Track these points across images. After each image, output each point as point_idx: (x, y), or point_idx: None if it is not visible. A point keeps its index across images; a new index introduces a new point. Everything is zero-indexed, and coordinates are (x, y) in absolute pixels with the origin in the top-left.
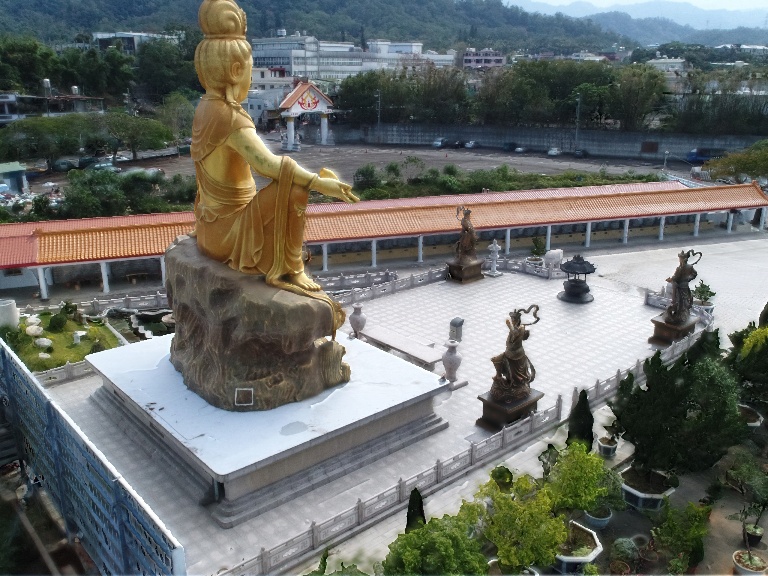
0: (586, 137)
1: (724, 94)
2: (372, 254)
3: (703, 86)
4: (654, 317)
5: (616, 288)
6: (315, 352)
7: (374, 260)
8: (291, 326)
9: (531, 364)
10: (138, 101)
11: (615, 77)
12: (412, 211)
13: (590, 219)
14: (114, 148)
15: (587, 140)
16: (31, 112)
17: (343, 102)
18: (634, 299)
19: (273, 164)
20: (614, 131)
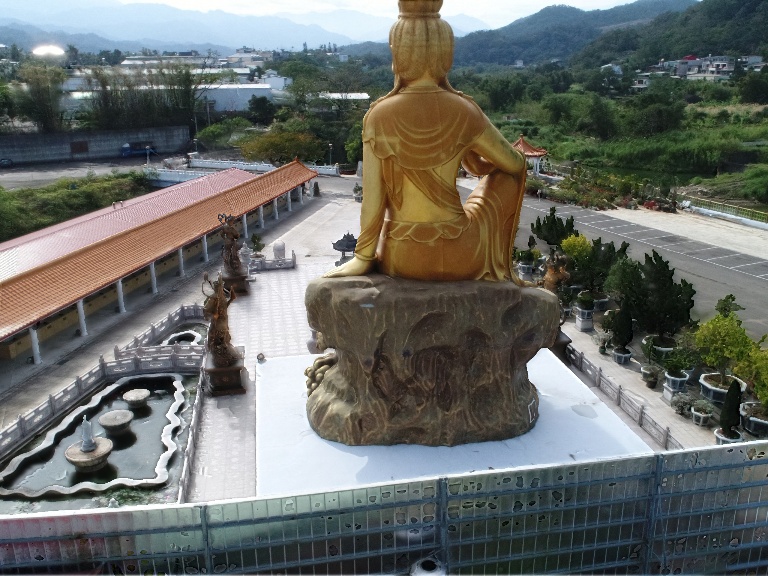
0: (3, 144)
1: (132, 89)
2: (120, 297)
3: (112, 82)
4: None
5: None
6: None
7: (123, 304)
8: None
9: None
10: None
11: (14, 75)
12: (129, 236)
13: (250, 210)
14: None
15: (5, 147)
16: None
17: None
18: None
19: None
20: (35, 134)
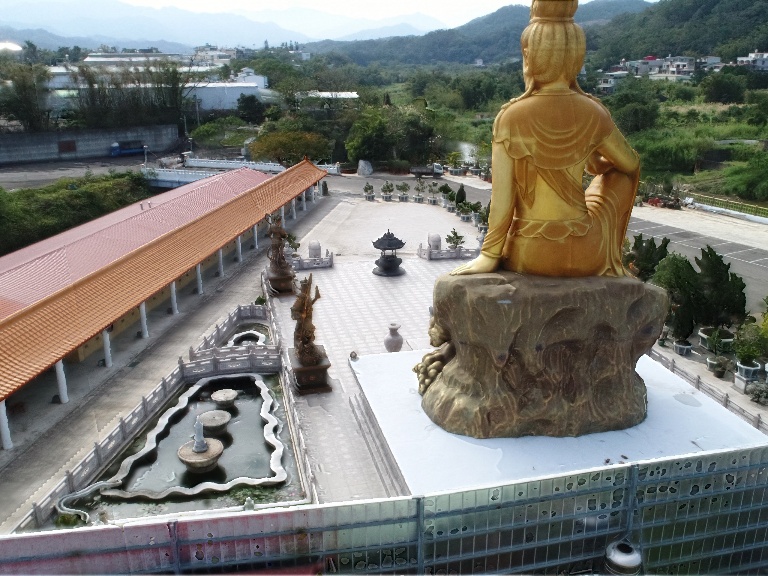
0: None
1: (119, 88)
2: (173, 298)
3: (100, 80)
4: None
5: (374, 259)
6: None
7: (176, 305)
8: None
9: None
10: None
11: None
12: (175, 237)
13: None
14: None
15: None
16: None
17: None
18: (410, 260)
19: None
20: (21, 133)
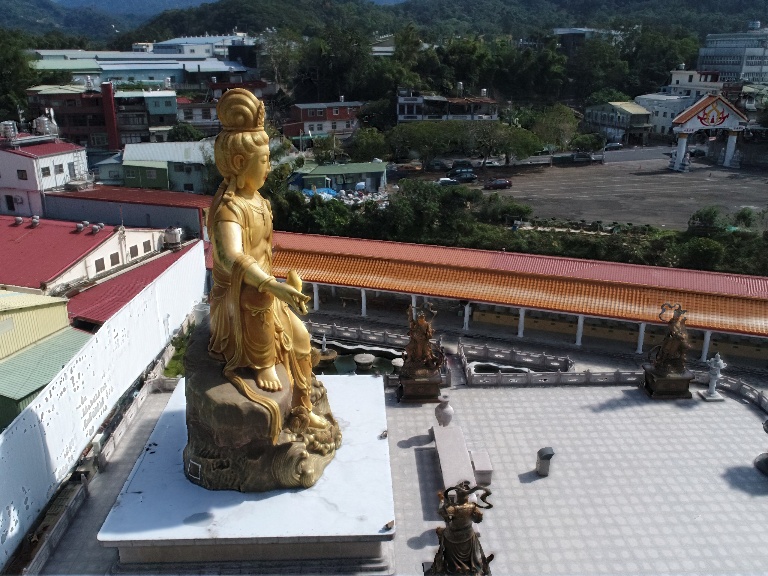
0: None
1: None
2: (577, 330)
3: None
4: None
5: None
6: (271, 449)
7: (579, 338)
8: (216, 422)
9: (483, 554)
10: (521, 109)
11: None
12: (642, 290)
13: None
14: (485, 154)
15: None
16: (433, 113)
17: (767, 117)
18: None
19: (228, 262)
20: None
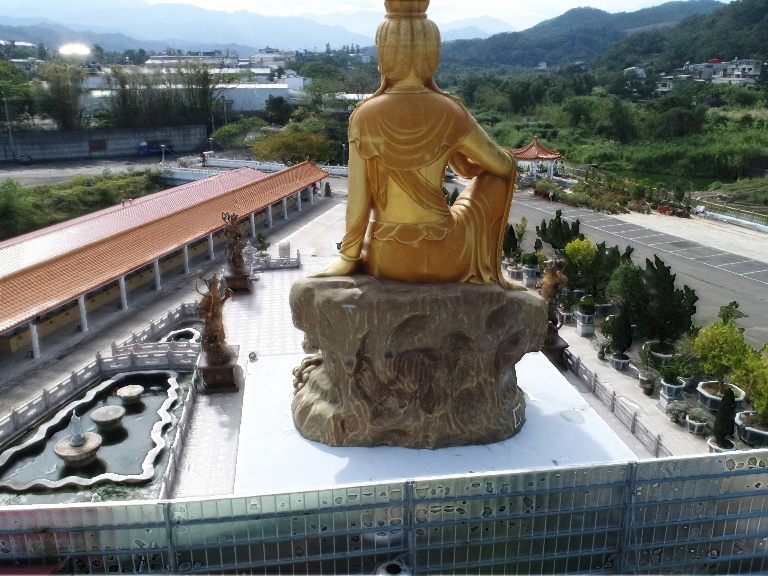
0: (23, 141)
1: (150, 88)
2: (122, 294)
3: (131, 81)
4: None
5: None
6: None
7: (125, 301)
8: None
9: None
10: None
11: (35, 73)
12: (133, 233)
13: (258, 209)
14: None
15: (25, 144)
16: None
17: None
18: None
19: (509, 158)
20: (54, 132)
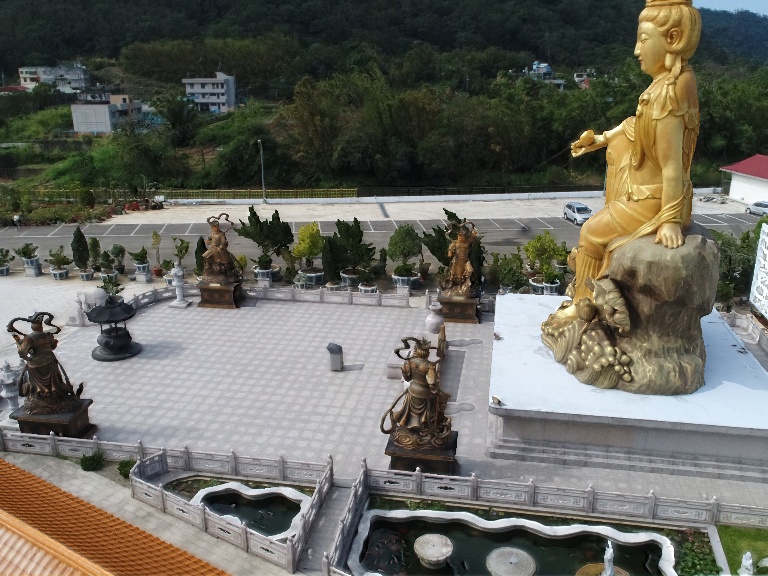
0: None
1: None
2: None
3: None
4: (229, 286)
5: None
6: None
7: None
8: None
9: None
10: None
11: None
12: None
13: None
14: None
15: None
16: None
17: None
18: (90, 333)
19: None
20: None
